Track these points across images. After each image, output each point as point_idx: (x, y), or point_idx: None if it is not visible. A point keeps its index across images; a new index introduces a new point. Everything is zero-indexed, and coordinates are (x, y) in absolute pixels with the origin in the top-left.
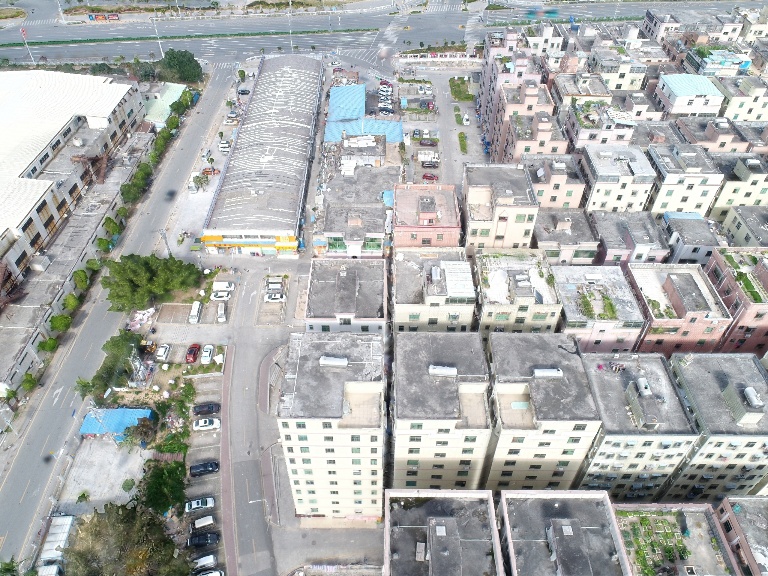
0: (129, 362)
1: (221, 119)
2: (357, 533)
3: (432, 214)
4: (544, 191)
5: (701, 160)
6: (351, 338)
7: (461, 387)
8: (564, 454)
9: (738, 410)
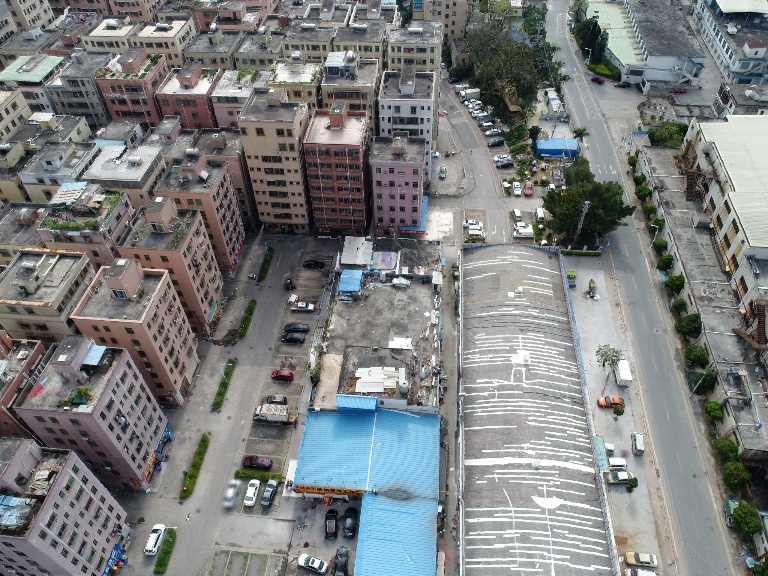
0: None
1: None
2: None
3: None
4: None
5: None
6: (406, 42)
7: None
8: None
9: None
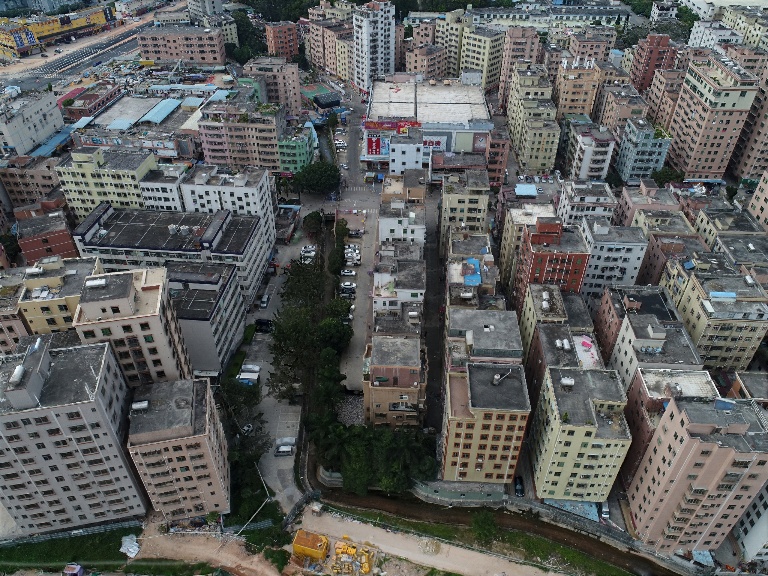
0: None
1: None
2: None
3: None
4: None
5: None
6: (760, 11)
7: None
8: None
9: None
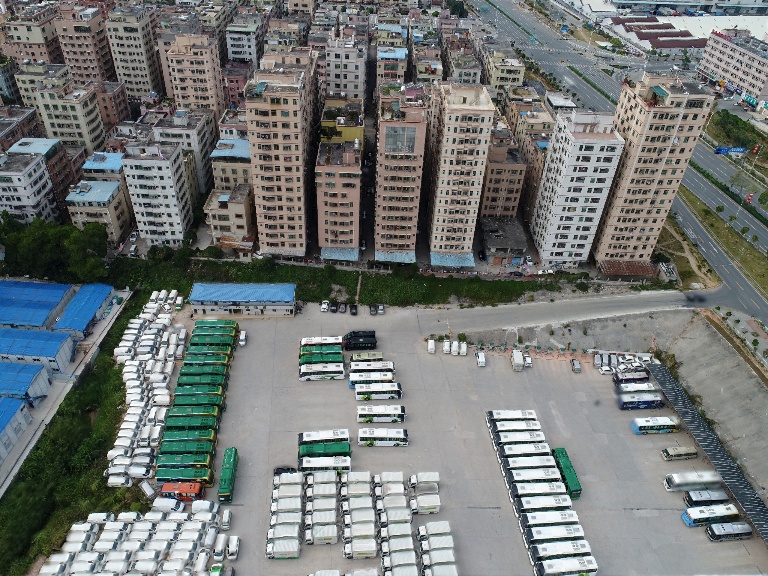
0: None
1: None
2: None
3: None
4: None
5: None
6: None
7: None
8: None
9: None
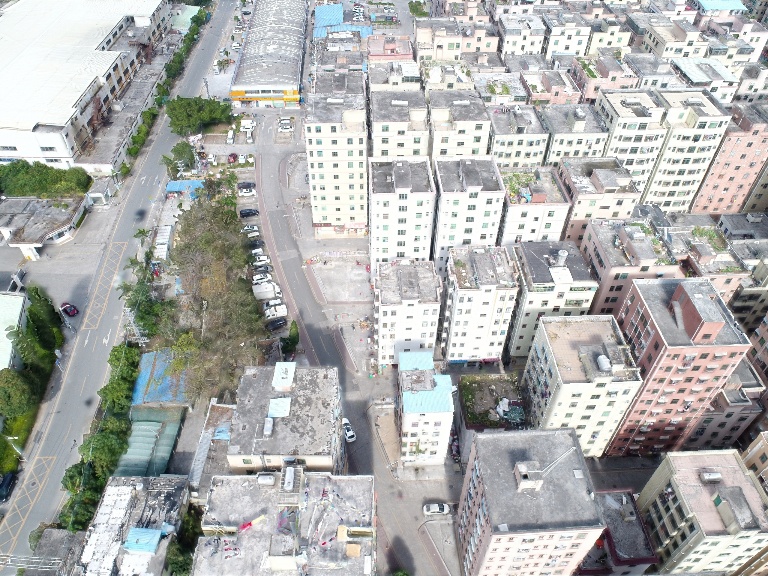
0: (193, 153)
1: (230, 30)
2: (352, 240)
3: (393, 45)
4: (471, 43)
5: (578, 21)
6: (345, 95)
7: (411, 115)
8: (473, 154)
9: (572, 123)
